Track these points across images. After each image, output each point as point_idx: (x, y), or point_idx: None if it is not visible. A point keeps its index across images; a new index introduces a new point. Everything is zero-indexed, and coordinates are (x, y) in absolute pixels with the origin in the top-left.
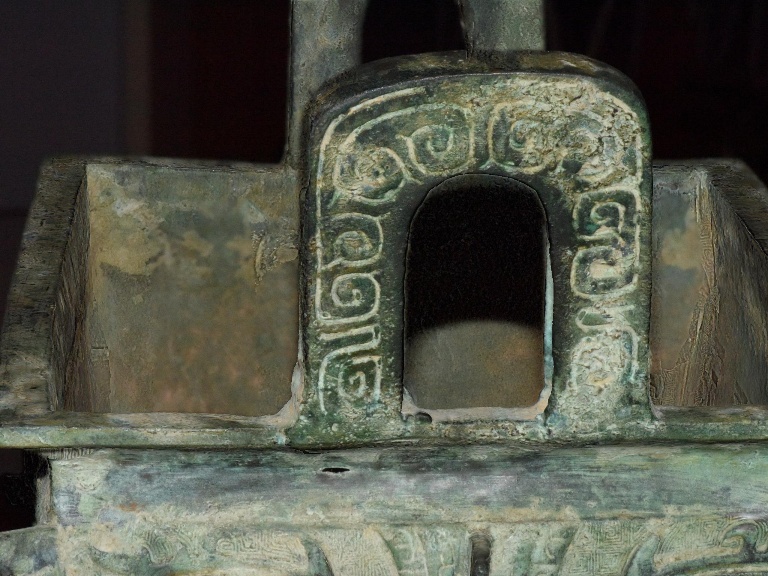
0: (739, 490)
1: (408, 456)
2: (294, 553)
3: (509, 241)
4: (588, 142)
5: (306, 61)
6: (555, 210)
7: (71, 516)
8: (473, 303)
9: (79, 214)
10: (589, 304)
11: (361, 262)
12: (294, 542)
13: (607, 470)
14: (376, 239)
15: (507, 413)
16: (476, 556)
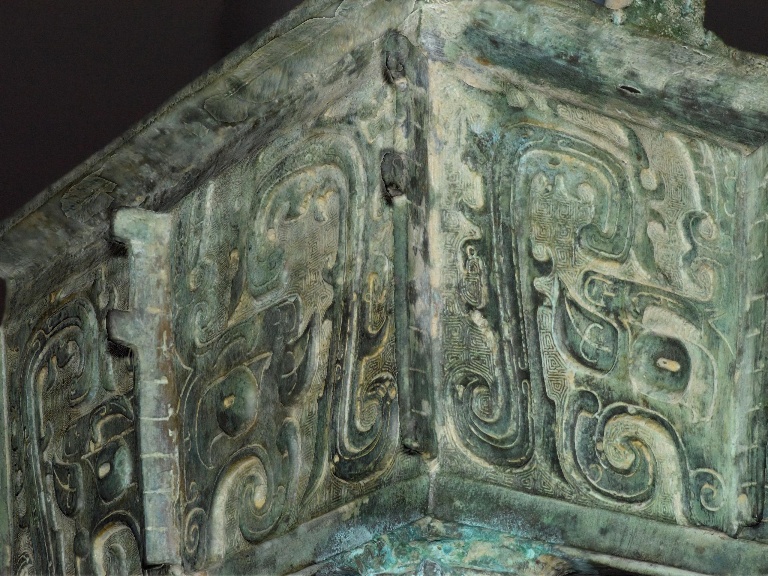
0: None
1: (687, 90)
2: (615, 134)
3: None
4: None
5: None
6: None
7: (438, 55)
8: None
9: (75, 218)
10: None
11: None
12: (614, 126)
13: None
14: None
15: None
16: None
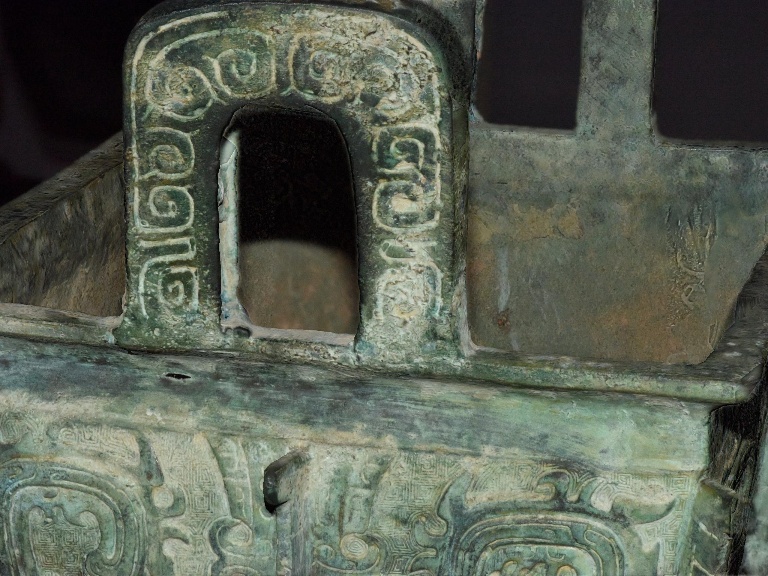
0: (556, 438)
1: (242, 370)
2: (129, 449)
3: (615, 210)
4: (385, 77)
5: (422, 17)
6: (354, 141)
7: None
8: (580, 269)
9: None
10: (392, 236)
11: (176, 175)
12: (130, 439)
13: (432, 405)
14: (188, 154)
15: (329, 337)
16: (268, 468)
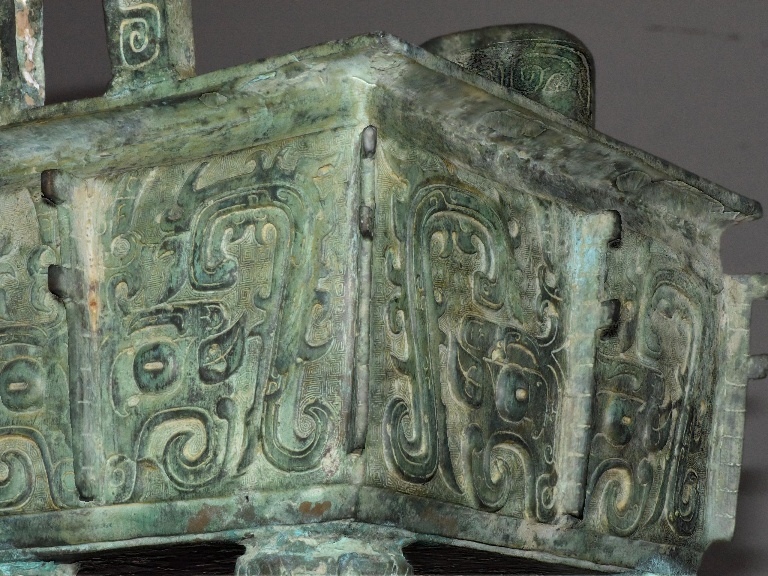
0: None
1: None
2: None
3: None
4: None
5: None
6: None
7: None
8: None
9: None
10: None
11: None
12: None
13: None
14: None
15: None
16: None
